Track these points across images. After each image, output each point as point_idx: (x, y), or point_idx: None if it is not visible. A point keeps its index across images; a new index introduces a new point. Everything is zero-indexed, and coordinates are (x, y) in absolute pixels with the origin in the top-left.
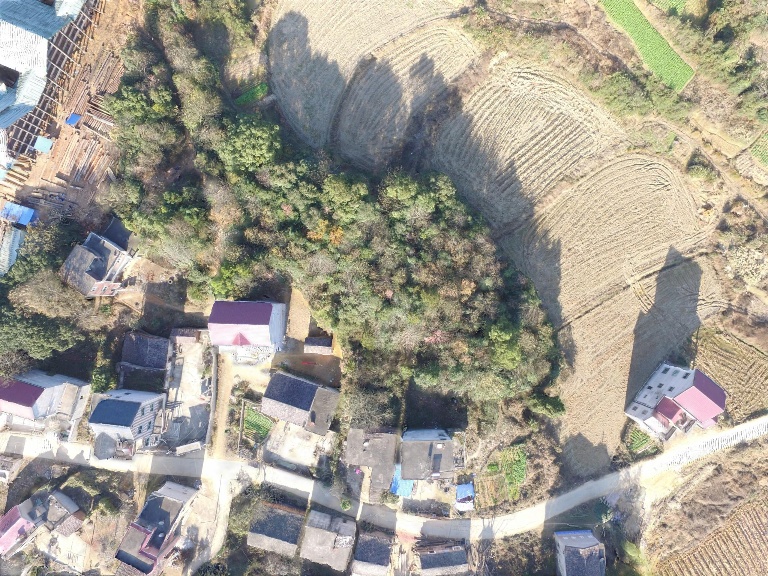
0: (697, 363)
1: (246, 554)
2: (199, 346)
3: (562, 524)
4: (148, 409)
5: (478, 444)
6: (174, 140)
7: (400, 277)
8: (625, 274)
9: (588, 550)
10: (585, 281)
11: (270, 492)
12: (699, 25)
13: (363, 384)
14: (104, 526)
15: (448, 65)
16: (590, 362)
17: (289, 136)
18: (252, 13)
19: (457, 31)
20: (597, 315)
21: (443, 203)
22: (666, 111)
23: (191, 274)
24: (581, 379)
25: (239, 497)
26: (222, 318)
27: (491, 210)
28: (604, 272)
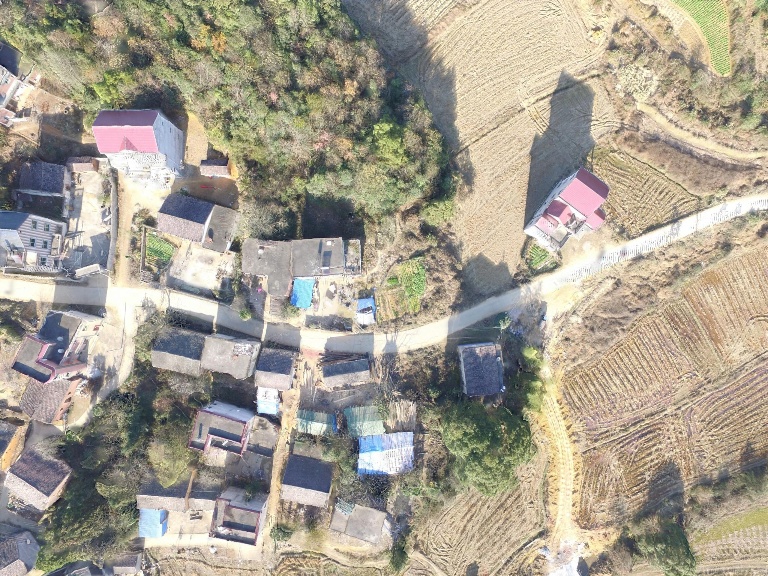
0: None
1: (155, 382)
2: (98, 176)
3: (465, 338)
4: (42, 226)
5: (377, 259)
6: None
7: (283, 78)
8: (520, 97)
9: (484, 349)
10: (481, 105)
11: (175, 318)
12: None
13: (260, 202)
14: (9, 356)
15: None
16: (489, 184)
17: None
18: None
19: None
20: (494, 138)
21: (328, 14)
22: None
23: (85, 101)
24: (480, 200)
25: (146, 326)
26: (106, 121)
27: (386, 39)
28: (499, 96)
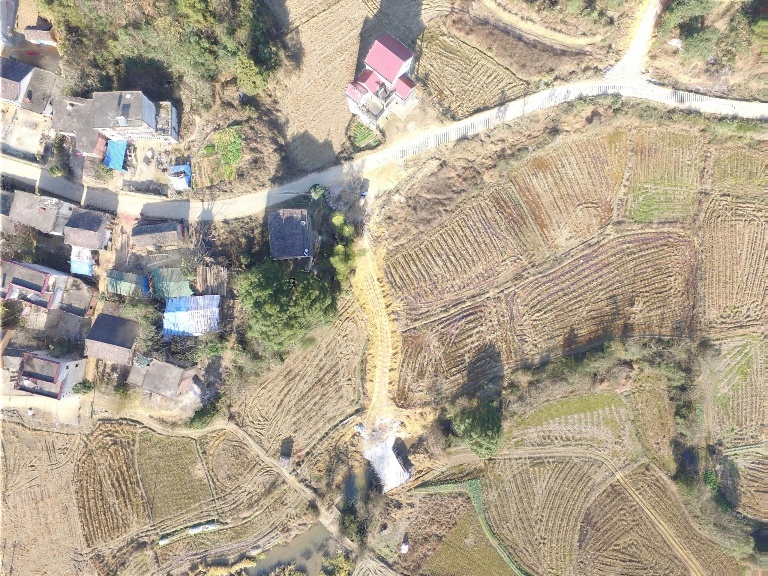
0: (422, 64)
1: None
2: None
3: None
4: None
5: (195, 127)
6: None
7: None
8: None
9: (287, 211)
10: None
11: None
12: None
13: None
14: None
15: None
16: (317, 63)
17: None
18: None
19: None
20: (325, 20)
21: None
22: None
23: None
24: (308, 79)
25: None
26: None
27: None
28: None
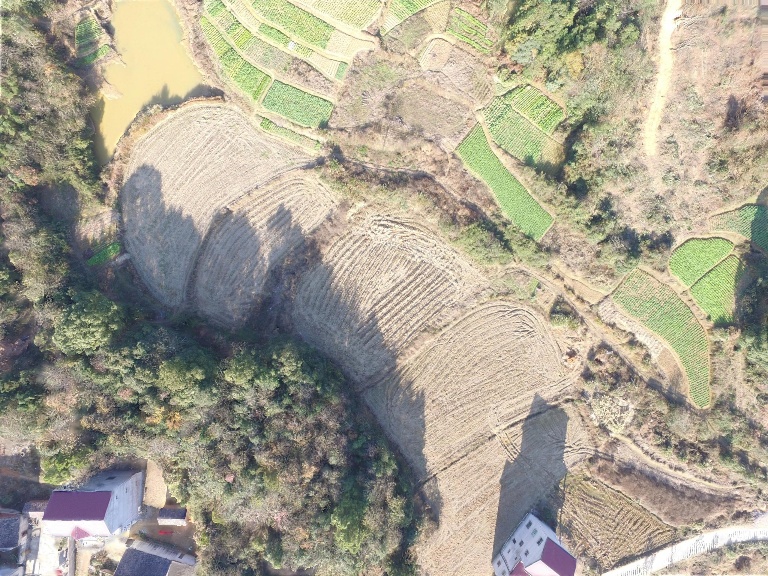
0: (565, 511)
1: None
2: None
3: None
4: None
5: None
6: (15, 316)
7: (238, 464)
8: (490, 424)
9: None
10: (450, 432)
11: None
12: (554, 176)
13: (218, 555)
14: None
15: (306, 216)
16: (457, 514)
17: (143, 297)
18: (102, 170)
19: (315, 180)
20: (463, 466)
21: (288, 378)
22: (527, 259)
23: (41, 448)
24: (448, 531)
25: None
26: (56, 514)
27: (353, 363)
28: (469, 423)
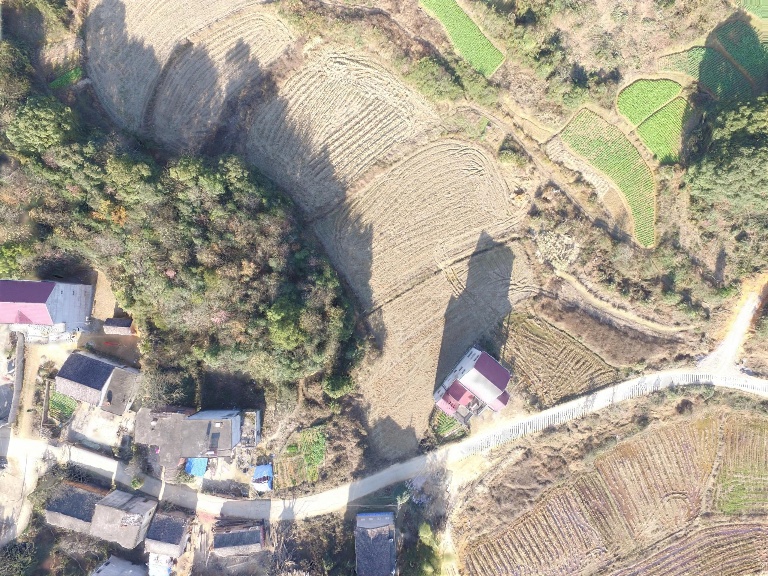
0: (508, 347)
1: (54, 533)
2: (7, 326)
3: None
4: None
5: (278, 425)
6: None
7: (179, 257)
8: (436, 258)
9: (376, 531)
10: (396, 265)
11: (75, 471)
12: (505, 10)
13: (161, 365)
14: None
15: (264, 50)
16: (400, 346)
17: (102, 120)
18: None
19: (274, 16)
20: (408, 299)
21: (233, 185)
22: (477, 96)
23: None
24: (391, 362)
25: (47, 476)
26: (0, 296)
27: (304, 194)
28: (415, 256)
